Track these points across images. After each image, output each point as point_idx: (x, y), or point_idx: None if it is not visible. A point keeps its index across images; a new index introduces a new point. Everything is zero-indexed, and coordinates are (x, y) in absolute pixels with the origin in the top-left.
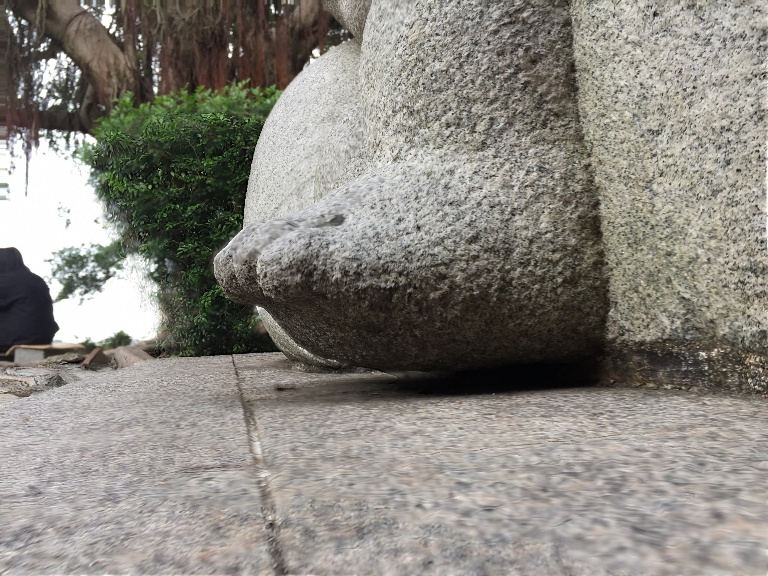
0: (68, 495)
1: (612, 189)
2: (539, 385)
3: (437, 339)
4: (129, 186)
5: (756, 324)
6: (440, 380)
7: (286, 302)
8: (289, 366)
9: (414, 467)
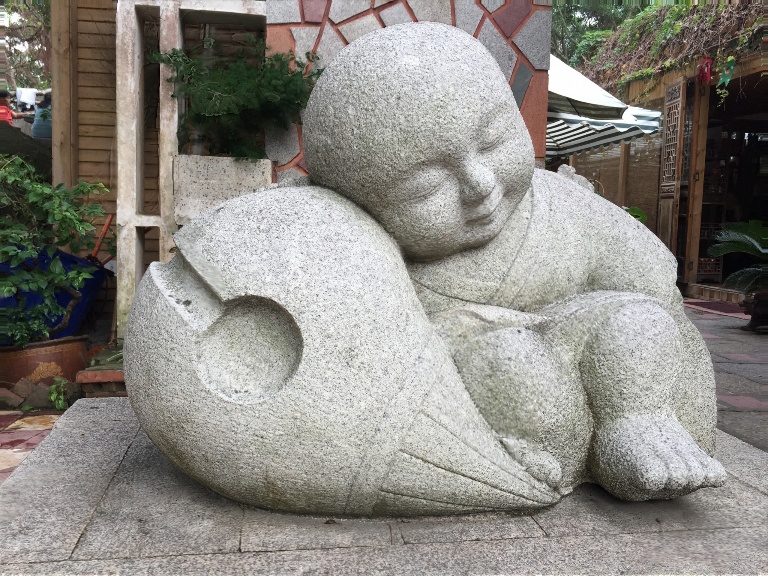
0: None
1: None
2: None
3: None
4: None
5: None
6: None
7: None
8: (434, 521)
9: None
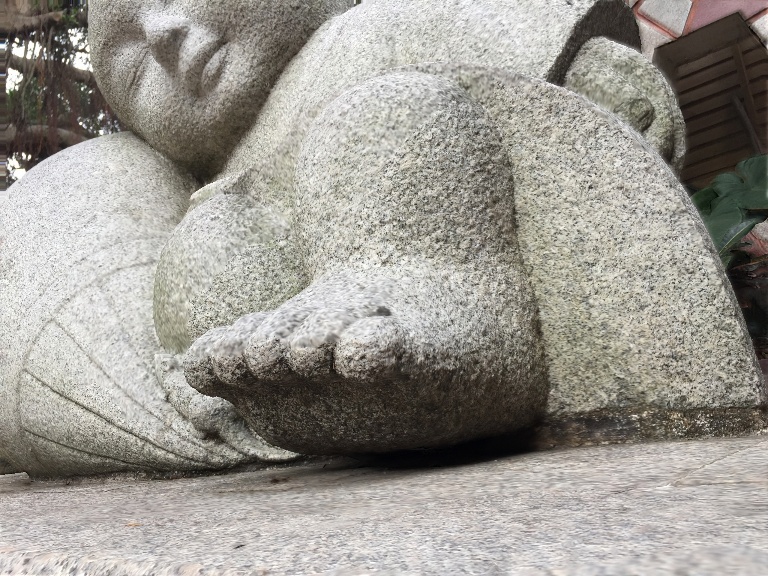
0: None
1: (552, 301)
2: (504, 453)
3: (467, 415)
4: None
5: (679, 392)
6: (438, 455)
7: (370, 383)
8: (83, 483)
9: (743, 467)
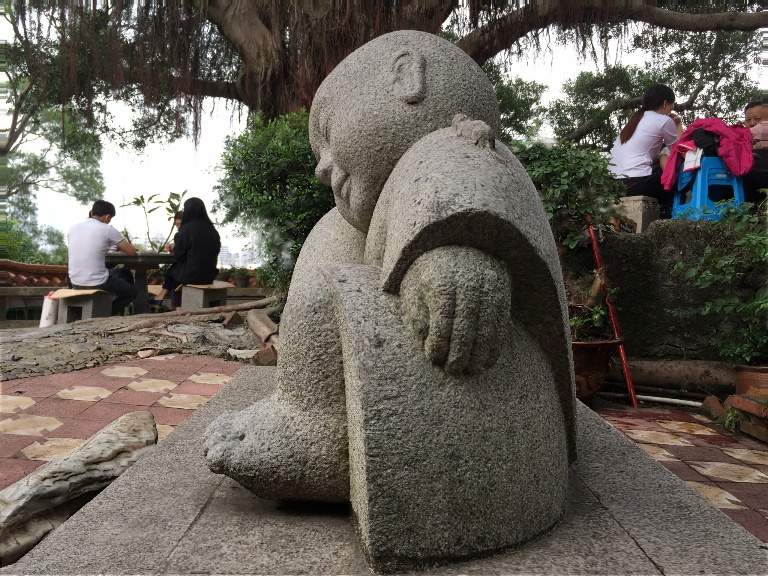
0: (110, 575)
1: (349, 442)
2: (326, 513)
3: (275, 494)
4: (255, 196)
5: None
6: None
7: None
8: None
9: None
